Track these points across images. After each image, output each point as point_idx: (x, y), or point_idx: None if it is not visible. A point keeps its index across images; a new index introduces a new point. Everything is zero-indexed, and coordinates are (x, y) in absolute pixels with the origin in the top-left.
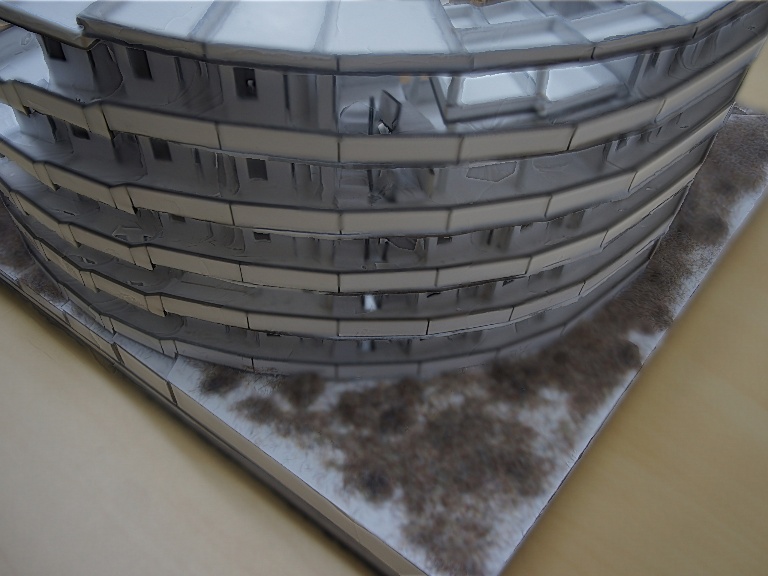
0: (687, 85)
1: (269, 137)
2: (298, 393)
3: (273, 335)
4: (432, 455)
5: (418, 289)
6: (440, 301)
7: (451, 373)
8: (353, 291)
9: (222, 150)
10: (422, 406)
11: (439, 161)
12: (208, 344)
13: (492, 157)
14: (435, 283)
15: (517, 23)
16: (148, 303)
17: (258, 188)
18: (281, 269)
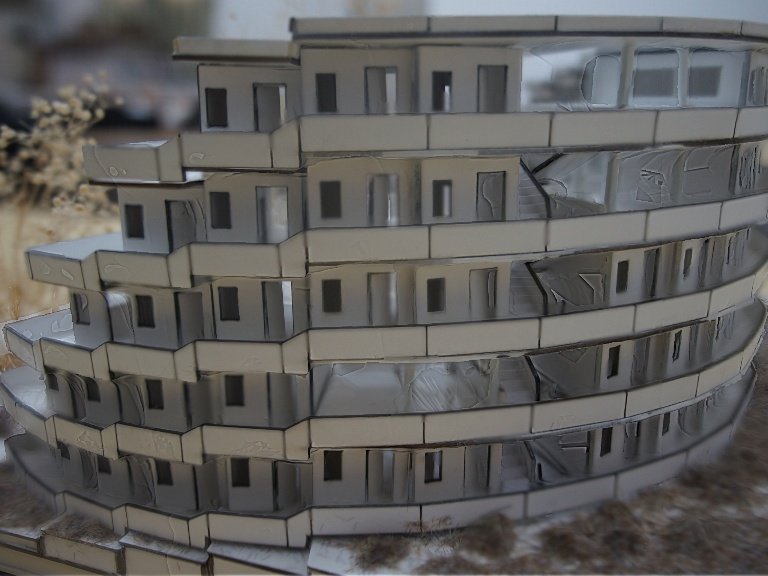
0: None
1: (482, 122)
2: (491, 538)
3: (432, 481)
4: (696, 565)
5: (617, 336)
6: (620, 384)
7: (648, 491)
8: (553, 345)
9: (429, 150)
10: (642, 526)
11: (638, 142)
12: (357, 504)
13: (679, 140)
14: (633, 326)
15: None
16: (287, 442)
17: (446, 221)
18: (475, 322)
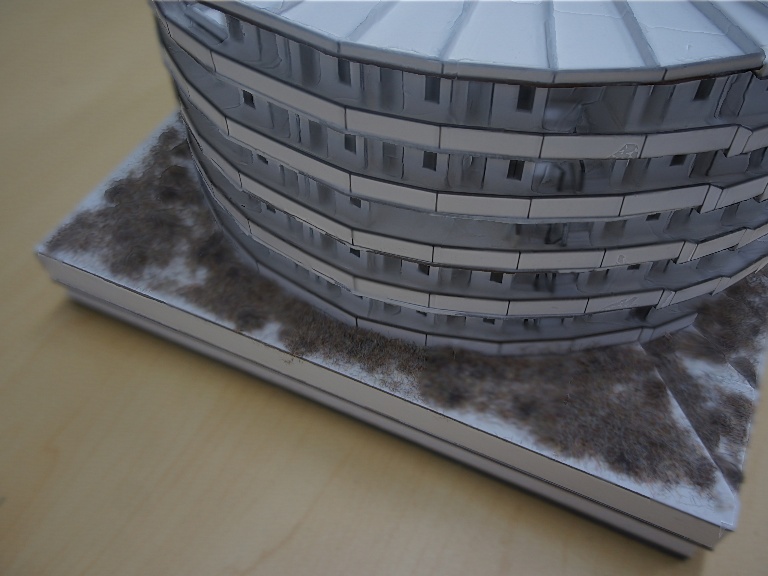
0: (232, 58)
1: None
2: None
3: None
4: (140, 215)
5: None
6: None
7: (210, 215)
8: None
9: None
10: (181, 206)
11: None
12: None
13: None
14: None
15: None
16: None
17: None
18: None
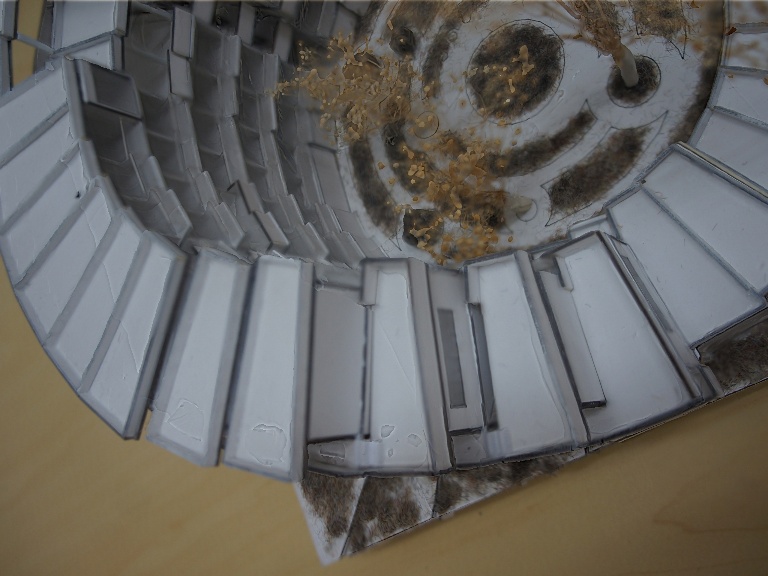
0: None
1: None
2: None
3: None
4: None
5: None
6: None
7: None
8: None
9: None
10: None
11: None
12: None
13: None
14: None
15: (3, 5)
16: None
17: None
18: None
